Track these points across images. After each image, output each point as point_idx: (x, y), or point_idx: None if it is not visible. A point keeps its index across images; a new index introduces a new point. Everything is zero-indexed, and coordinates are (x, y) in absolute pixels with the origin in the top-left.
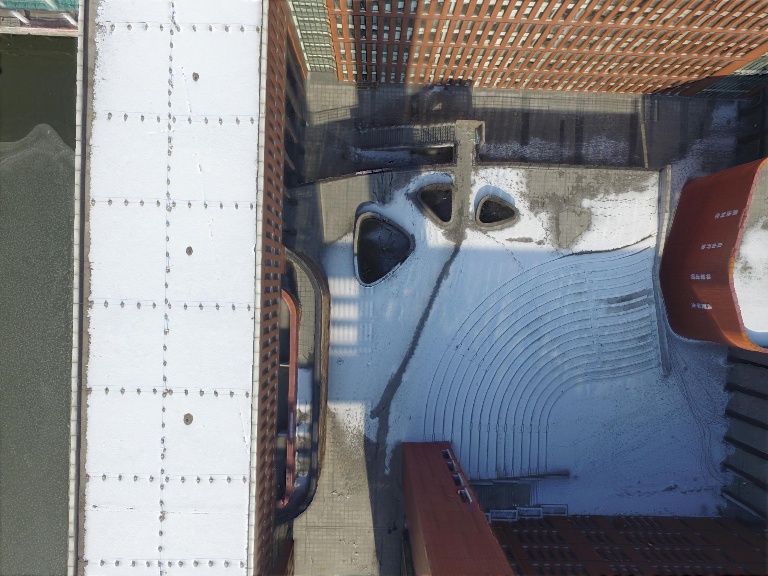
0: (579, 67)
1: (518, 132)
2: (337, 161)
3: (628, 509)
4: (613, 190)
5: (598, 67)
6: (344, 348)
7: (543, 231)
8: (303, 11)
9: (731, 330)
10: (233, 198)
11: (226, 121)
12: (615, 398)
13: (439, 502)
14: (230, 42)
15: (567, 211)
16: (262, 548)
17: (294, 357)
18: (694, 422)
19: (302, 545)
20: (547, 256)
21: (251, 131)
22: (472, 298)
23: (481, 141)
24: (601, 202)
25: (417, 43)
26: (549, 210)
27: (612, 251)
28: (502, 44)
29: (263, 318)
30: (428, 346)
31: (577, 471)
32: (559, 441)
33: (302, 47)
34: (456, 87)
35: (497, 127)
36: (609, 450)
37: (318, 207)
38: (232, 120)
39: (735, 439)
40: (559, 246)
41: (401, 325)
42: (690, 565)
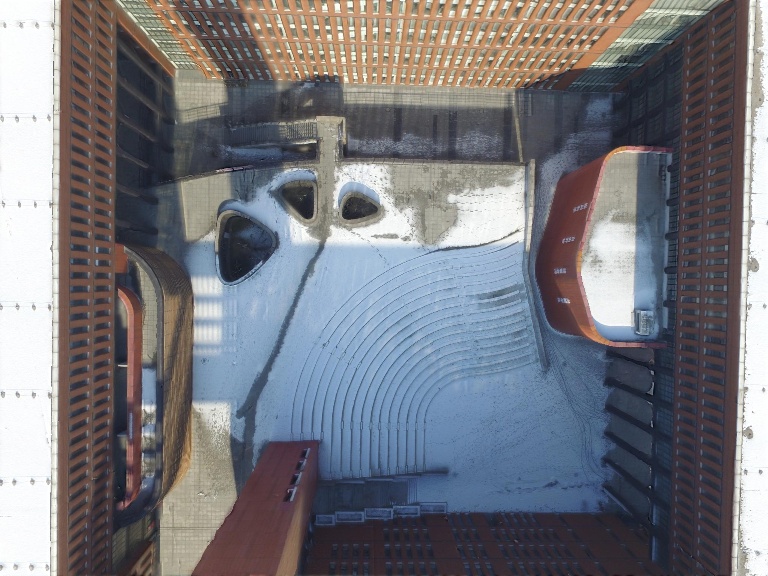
0: (437, 61)
1: (391, 128)
2: (207, 159)
3: (508, 506)
4: (479, 185)
5: (456, 61)
6: (208, 347)
7: (409, 227)
8: (134, 7)
9: (584, 324)
10: (31, 197)
11: (22, 119)
12: (493, 394)
13: (258, 501)
14: (25, 39)
15: (433, 207)
16: (81, 550)
17: (132, 357)
18: (574, 417)
19: (169, 547)
20: (413, 252)
21: (48, 128)
22: (338, 295)
23: (342, 137)
24: (467, 197)
25: (261, 39)
26: (414, 206)
27: (479, 246)
28: (345, 39)
29: (71, 318)
30: (294, 344)
31: (456, 468)
32: (437, 438)
33: (156, 44)
34: (327, 83)
35: (369, 123)
36: (488, 447)
37: (179, 206)
38: (29, 118)
39: (614, 434)
40: (425, 242)
41: (266, 324)
42: (546, 561)
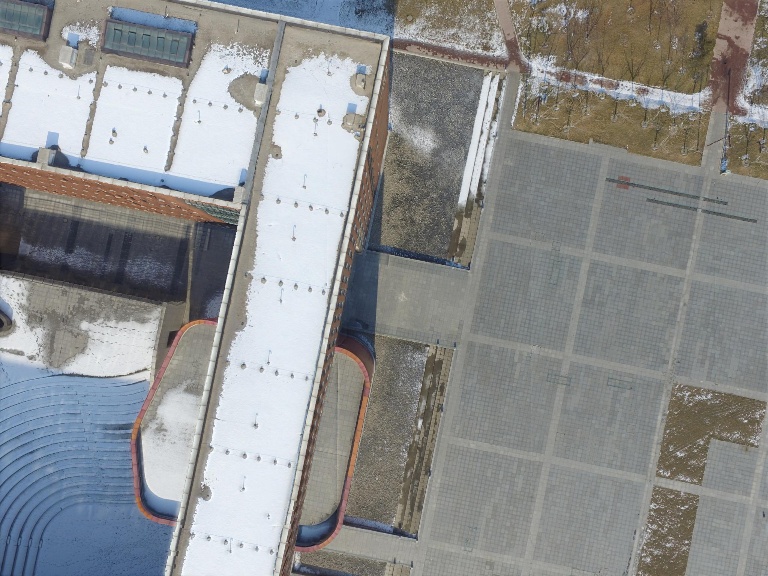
0: None
1: (65, 239)
2: None
3: None
4: (114, 317)
5: None
6: None
7: (36, 346)
8: None
9: None
10: None
11: None
12: (117, 525)
13: None
14: None
15: (64, 330)
16: None
17: None
18: None
19: None
20: (36, 372)
21: None
22: None
23: None
24: (100, 327)
25: None
26: (46, 326)
27: (105, 378)
28: None
29: None
30: None
31: None
32: (52, 559)
33: None
34: (10, 185)
35: (44, 230)
36: None
37: None
38: None
39: None
40: (50, 364)
41: None
42: None
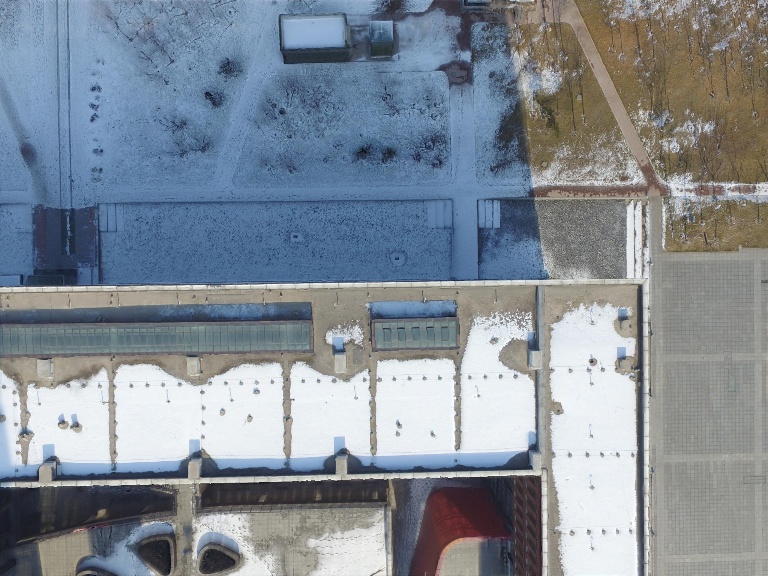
0: None
1: None
2: (73, 494)
3: None
4: (338, 528)
5: None
6: None
7: (269, 574)
8: None
9: None
10: None
11: None
12: None
13: None
14: None
15: (292, 552)
16: None
17: None
18: None
19: None
20: None
21: None
22: None
23: (195, 495)
24: (327, 541)
25: None
26: (274, 552)
27: None
28: None
29: None
30: None
31: None
32: None
33: None
34: None
35: None
36: None
37: (37, 565)
38: None
39: None
40: None
41: None
42: None
